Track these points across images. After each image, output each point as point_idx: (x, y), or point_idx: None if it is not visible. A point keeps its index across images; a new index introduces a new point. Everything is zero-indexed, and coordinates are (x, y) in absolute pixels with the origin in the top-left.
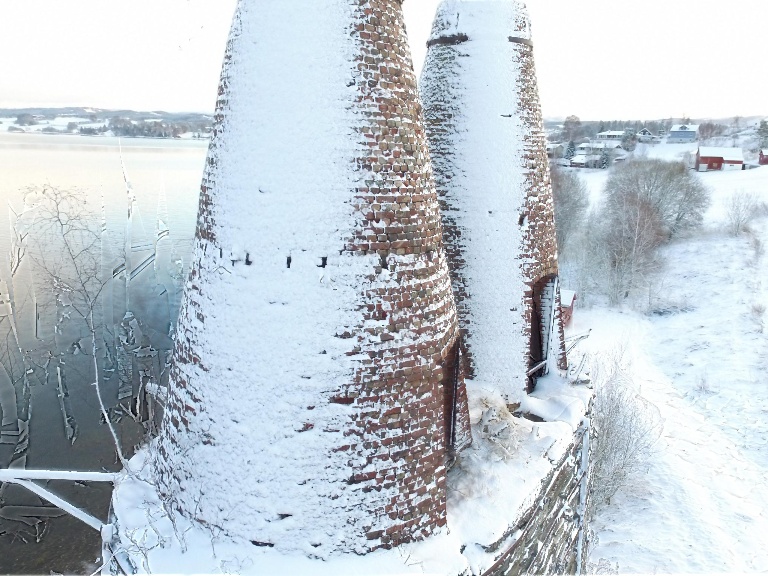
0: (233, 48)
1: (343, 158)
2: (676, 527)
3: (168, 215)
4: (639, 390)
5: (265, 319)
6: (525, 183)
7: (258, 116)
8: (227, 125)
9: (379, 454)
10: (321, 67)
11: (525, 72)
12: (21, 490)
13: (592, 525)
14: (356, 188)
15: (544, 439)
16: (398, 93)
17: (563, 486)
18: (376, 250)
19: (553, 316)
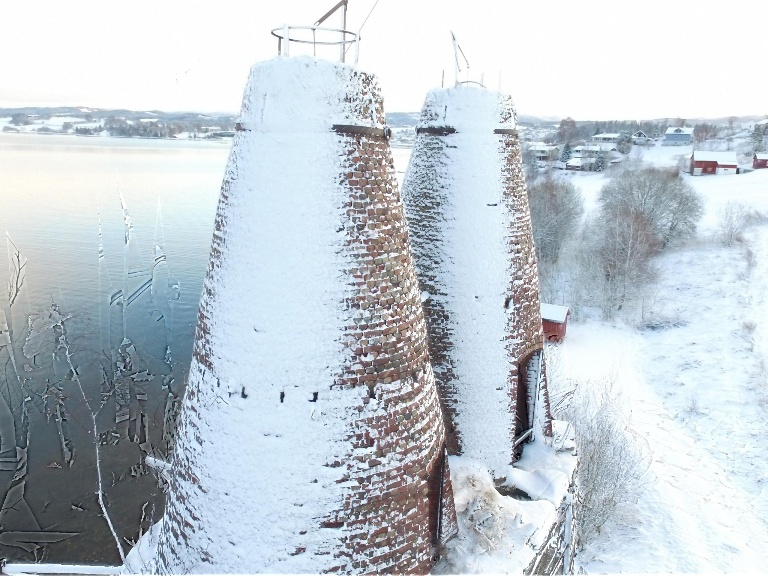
0: (229, 190)
1: (333, 299)
2: (664, 558)
3: (165, 240)
4: (629, 418)
5: (260, 450)
6: (510, 268)
7: (253, 259)
8: (224, 262)
9: (367, 572)
10: (312, 216)
11: (510, 161)
12: (19, 516)
13: (583, 554)
14: (345, 327)
15: (527, 527)
16: (385, 231)
17: (546, 566)
18: (364, 382)
19: (539, 387)
